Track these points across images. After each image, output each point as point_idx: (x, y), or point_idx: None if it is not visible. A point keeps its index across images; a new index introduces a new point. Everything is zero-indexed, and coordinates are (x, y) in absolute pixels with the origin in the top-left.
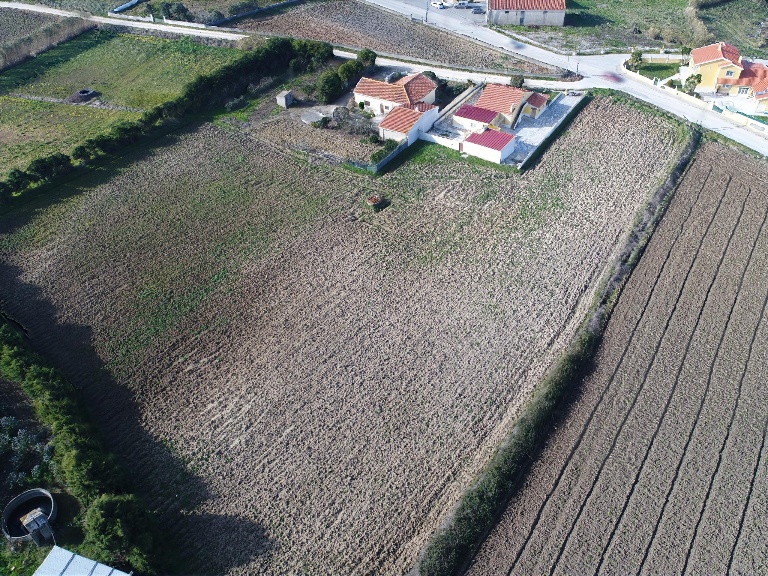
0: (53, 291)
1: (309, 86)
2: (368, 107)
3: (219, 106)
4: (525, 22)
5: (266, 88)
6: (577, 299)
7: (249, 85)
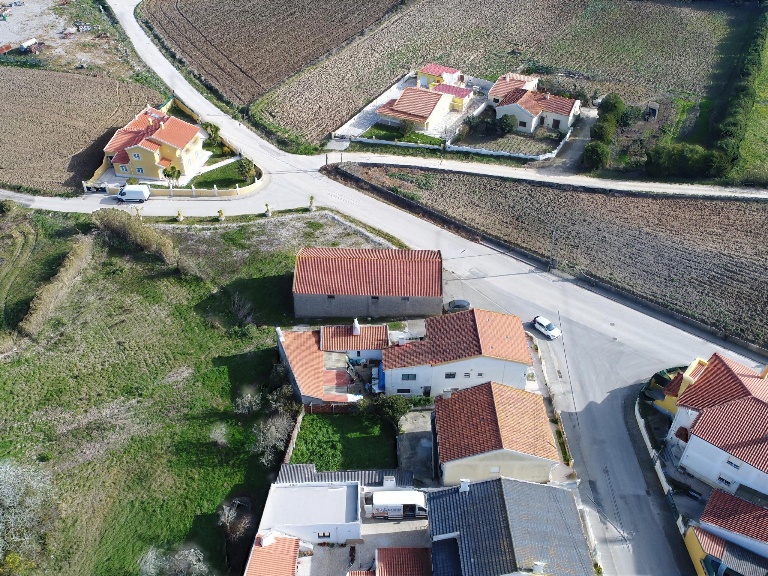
0: (665, 6)
1: (633, 107)
2: None
3: None
4: None
5: None
6: None
7: None
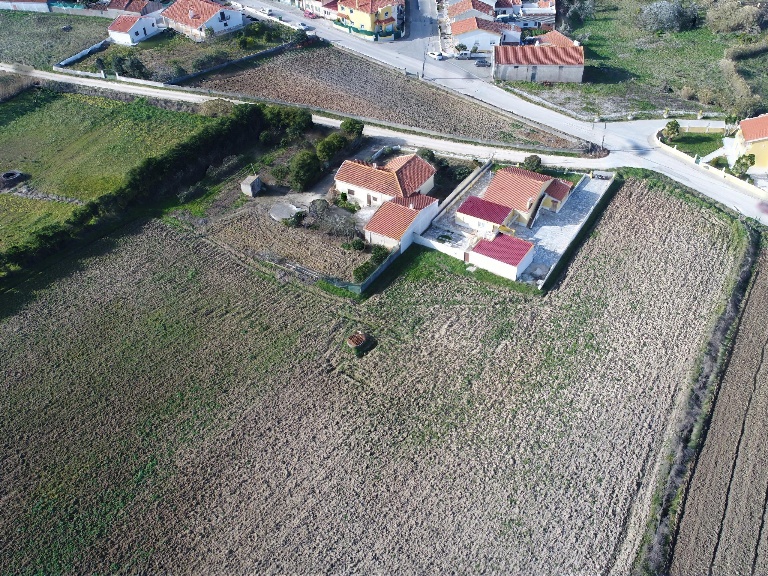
0: None
1: (281, 170)
2: (352, 196)
3: (171, 195)
4: (537, 78)
5: (230, 169)
6: (628, 507)
7: (208, 168)
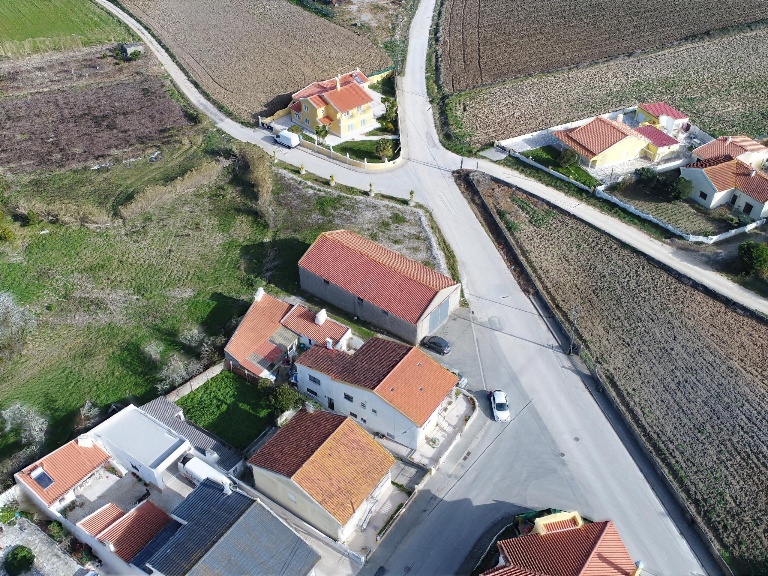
0: None
1: None
2: None
3: None
4: None
5: None
6: None
7: None
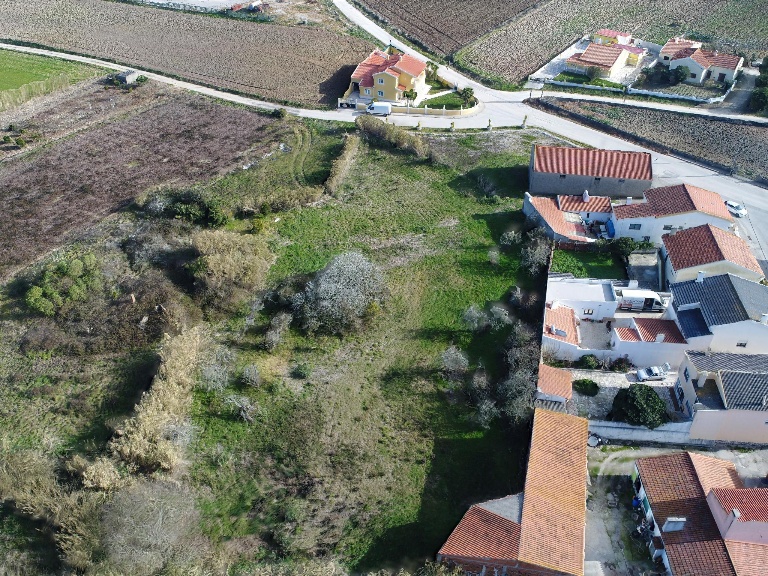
0: None
1: None
2: None
3: None
4: None
5: None
6: (560, 0)
7: None
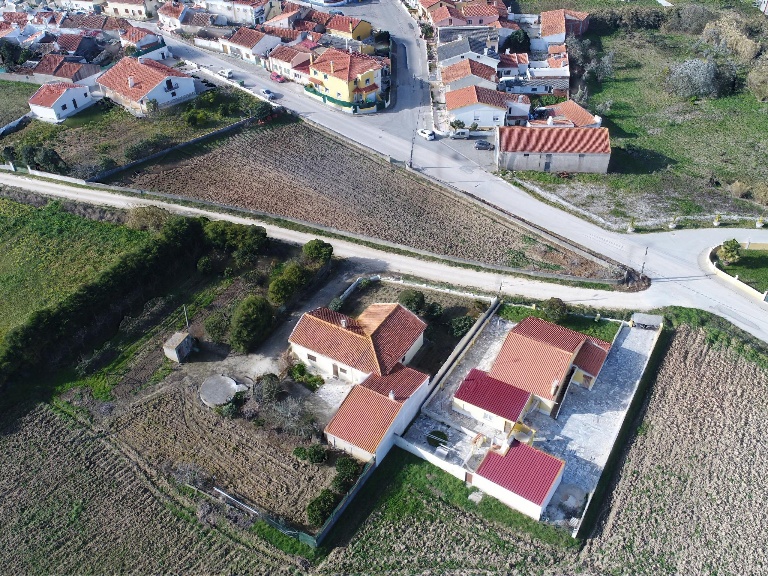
0: None
1: (218, 325)
2: (313, 363)
3: (69, 362)
4: (552, 168)
5: (154, 316)
6: None
7: (122, 320)
